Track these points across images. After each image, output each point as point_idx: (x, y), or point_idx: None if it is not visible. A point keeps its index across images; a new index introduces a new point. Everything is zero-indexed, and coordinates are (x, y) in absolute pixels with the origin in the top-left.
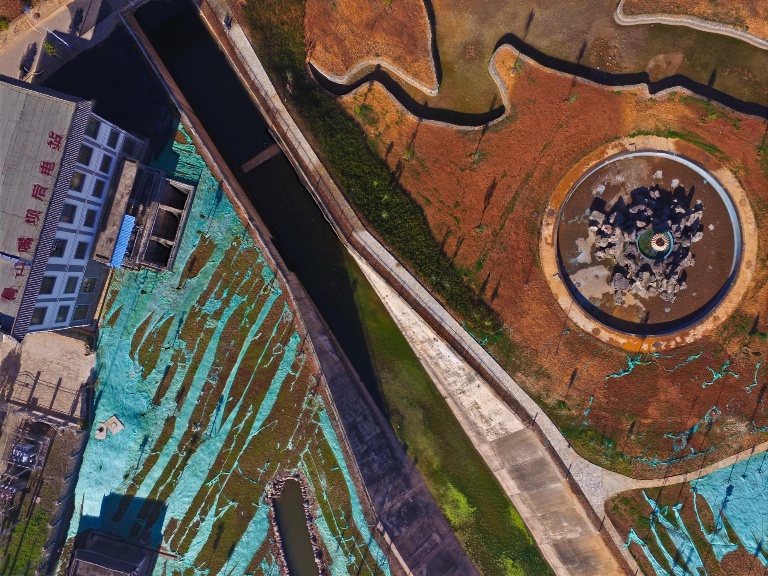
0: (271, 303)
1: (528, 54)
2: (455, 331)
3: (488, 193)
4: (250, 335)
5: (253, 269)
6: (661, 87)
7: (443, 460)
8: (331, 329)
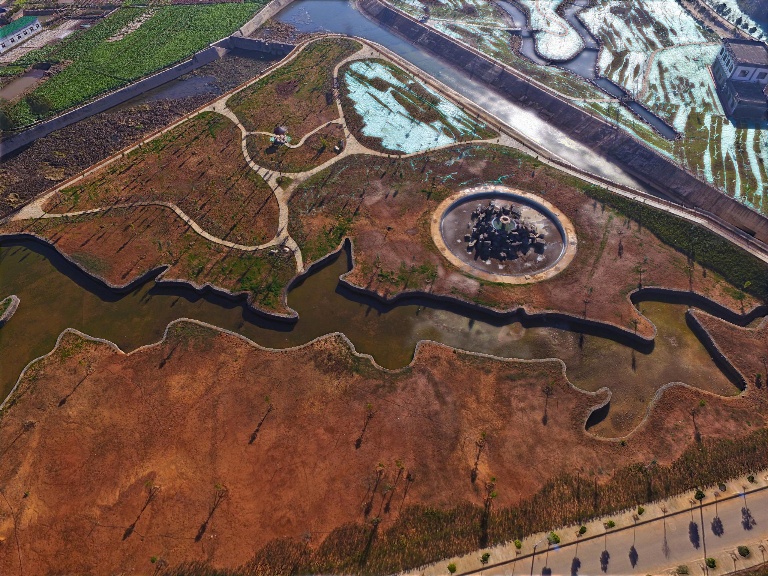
0: (737, 193)
1: (625, 340)
2: (613, 189)
3: (622, 250)
4: (739, 181)
5: (760, 206)
6: (511, 319)
7: (584, 158)
8: (680, 204)
